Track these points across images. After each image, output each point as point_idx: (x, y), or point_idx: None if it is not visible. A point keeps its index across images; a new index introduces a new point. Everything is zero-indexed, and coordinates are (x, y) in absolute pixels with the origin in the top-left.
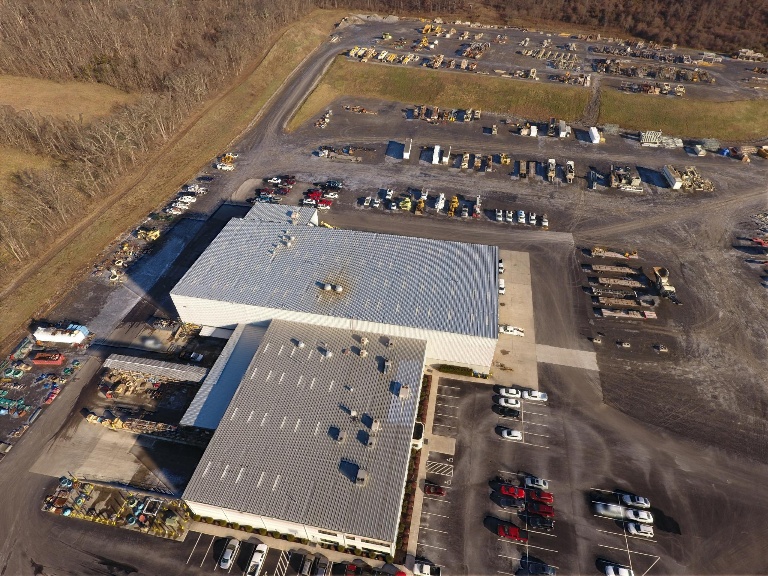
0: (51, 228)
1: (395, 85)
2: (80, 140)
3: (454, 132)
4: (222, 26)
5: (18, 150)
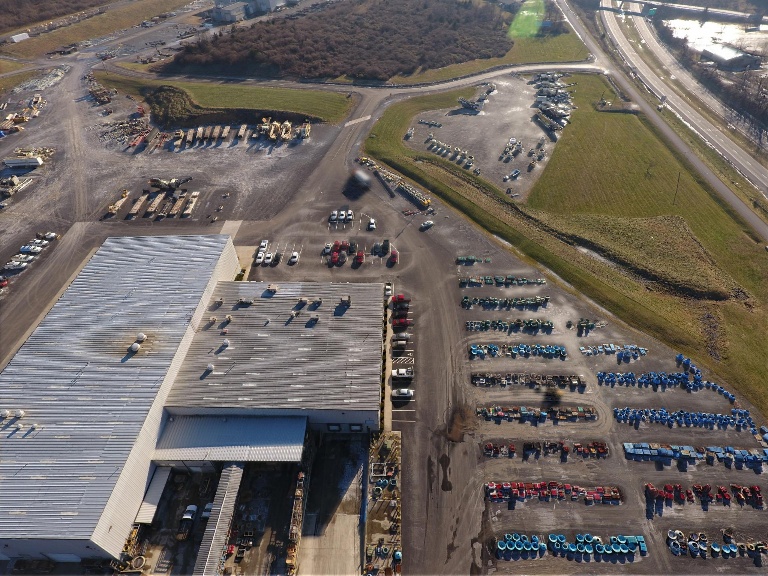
0: None
1: None
2: None
3: None
4: None
5: None
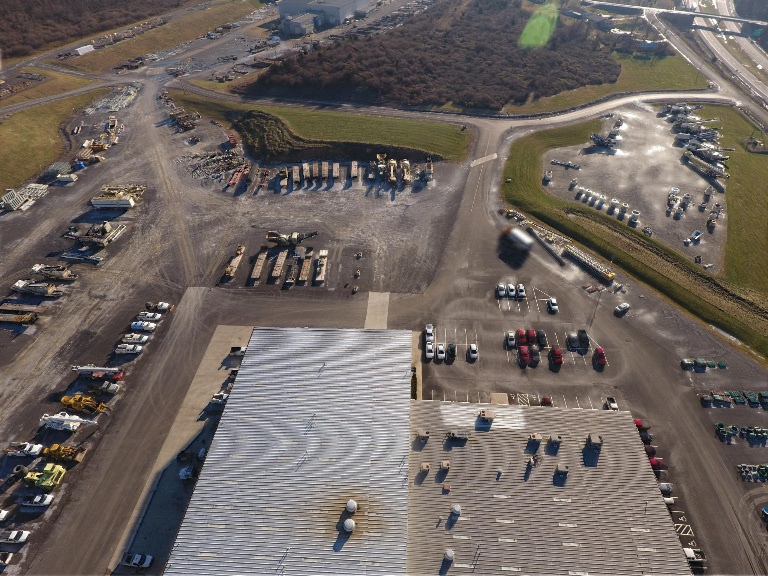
0: None
1: None
2: None
3: None
4: None
5: None
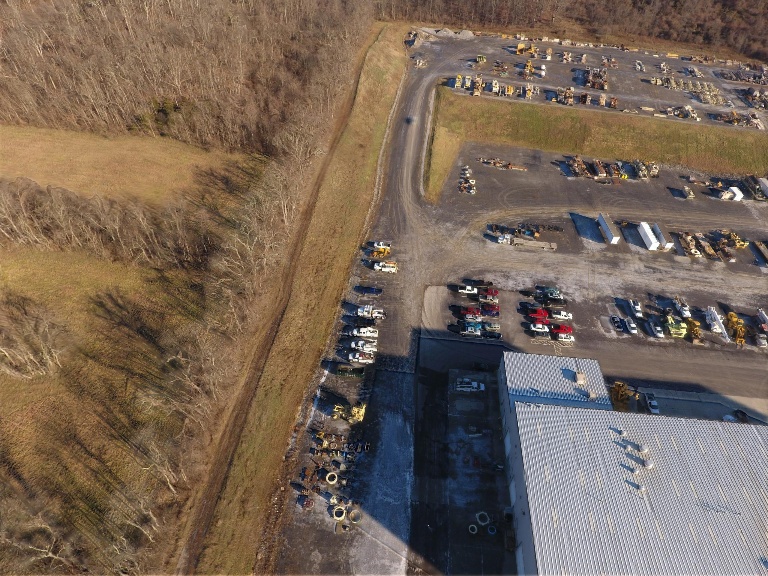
0: (201, 416)
1: (527, 127)
2: (185, 242)
3: (639, 197)
4: (305, 53)
5: (84, 254)
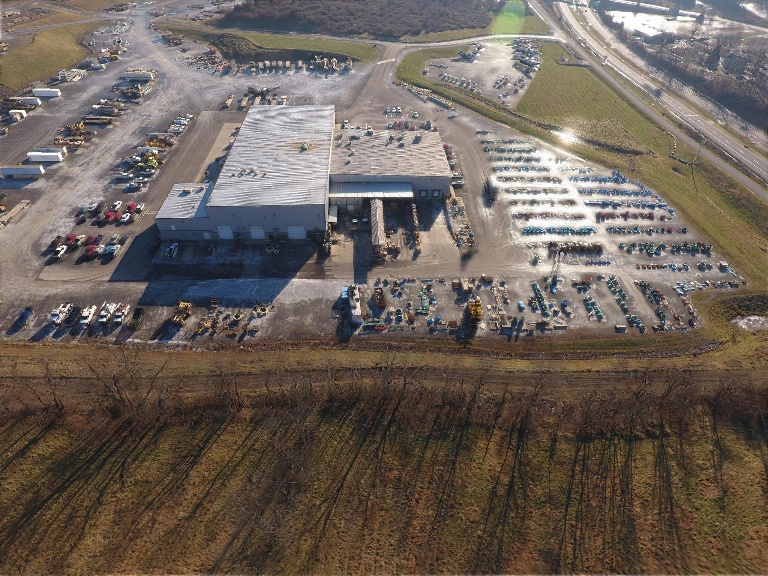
0: None
1: None
2: None
3: None
4: None
5: None
